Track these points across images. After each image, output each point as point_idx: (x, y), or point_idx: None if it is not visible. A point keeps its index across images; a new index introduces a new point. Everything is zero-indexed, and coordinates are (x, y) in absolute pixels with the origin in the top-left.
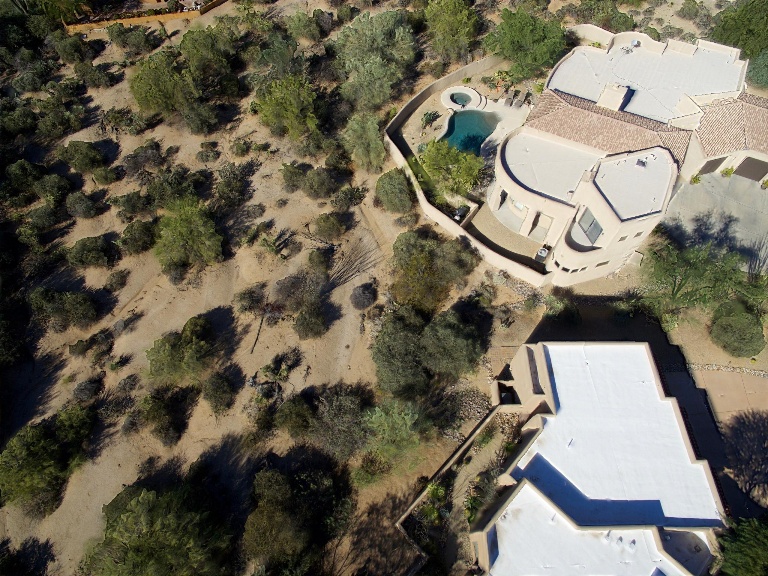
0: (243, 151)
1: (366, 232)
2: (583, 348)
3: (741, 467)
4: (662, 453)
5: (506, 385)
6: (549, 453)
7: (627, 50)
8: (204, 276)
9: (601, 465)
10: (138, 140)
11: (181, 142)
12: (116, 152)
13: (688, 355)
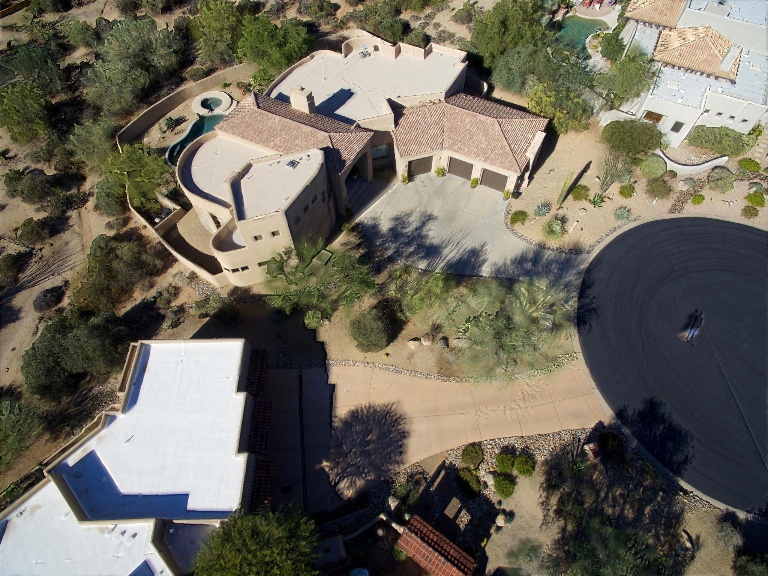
0: None
1: (75, 236)
2: (185, 346)
3: (338, 460)
4: (213, 447)
5: None
6: (104, 450)
7: (364, 54)
8: None
9: (149, 461)
10: None
11: None
12: None
13: (330, 351)
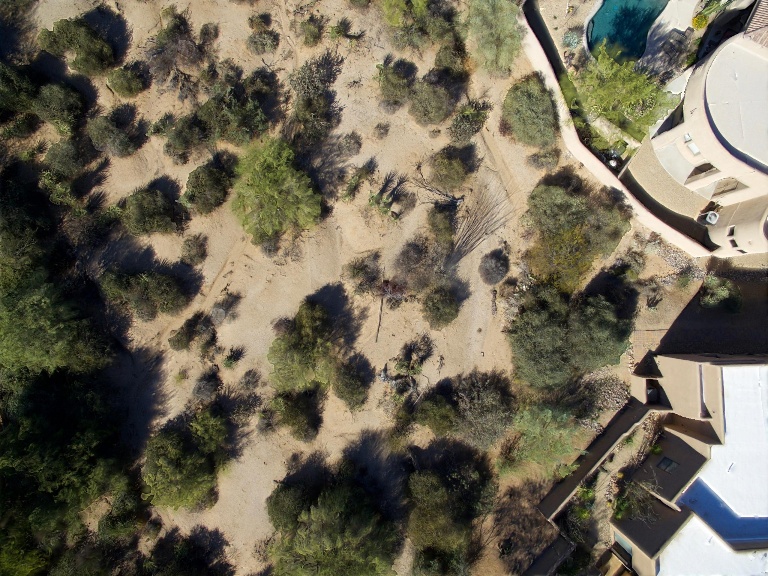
0: (314, 37)
1: (492, 175)
2: (759, 367)
3: None
4: None
5: None
6: (709, 477)
7: None
8: (302, 244)
9: (756, 487)
10: (151, 10)
11: (217, 16)
12: (124, 33)
13: None
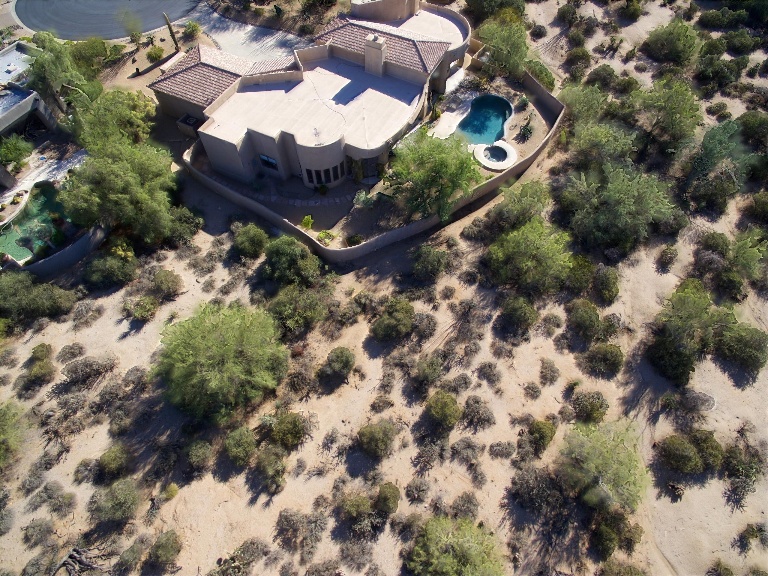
0: None
1: (551, 63)
2: None
3: None
4: None
5: None
6: None
7: None
8: None
9: None
10: None
11: None
12: None
13: None
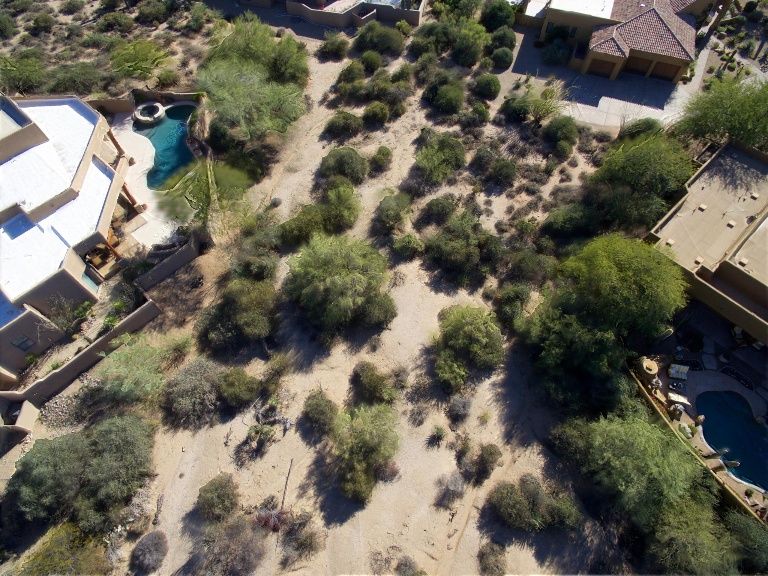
0: None
1: None
2: None
3: None
4: None
5: (12, 428)
6: None
7: None
8: (371, 575)
9: None
10: None
11: None
12: None
13: None
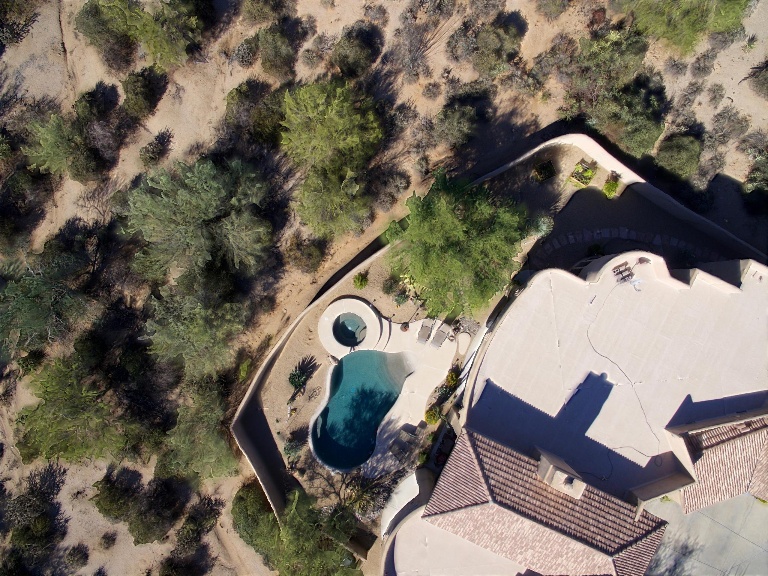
0: (32, 455)
1: (227, 574)
2: None
3: None
4: None
5: None
6: None
7: (623, 276)
8: None
9: None
10: None
11: None
12: None
13: None
